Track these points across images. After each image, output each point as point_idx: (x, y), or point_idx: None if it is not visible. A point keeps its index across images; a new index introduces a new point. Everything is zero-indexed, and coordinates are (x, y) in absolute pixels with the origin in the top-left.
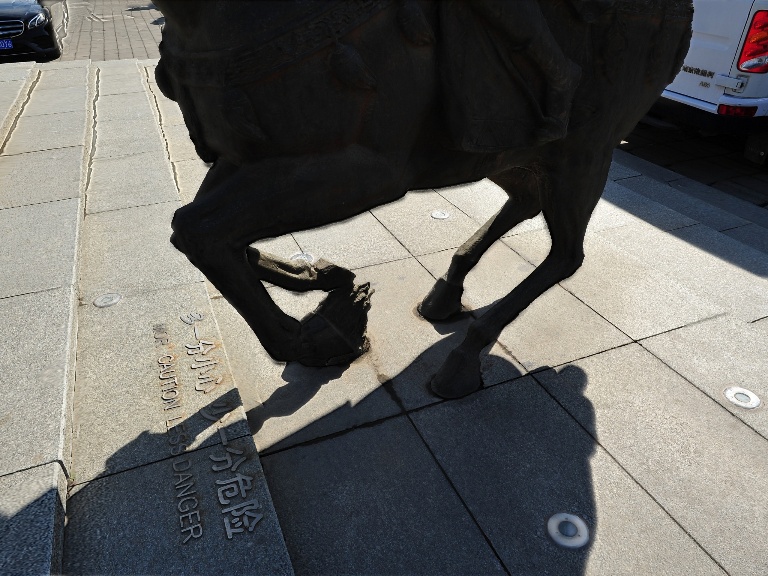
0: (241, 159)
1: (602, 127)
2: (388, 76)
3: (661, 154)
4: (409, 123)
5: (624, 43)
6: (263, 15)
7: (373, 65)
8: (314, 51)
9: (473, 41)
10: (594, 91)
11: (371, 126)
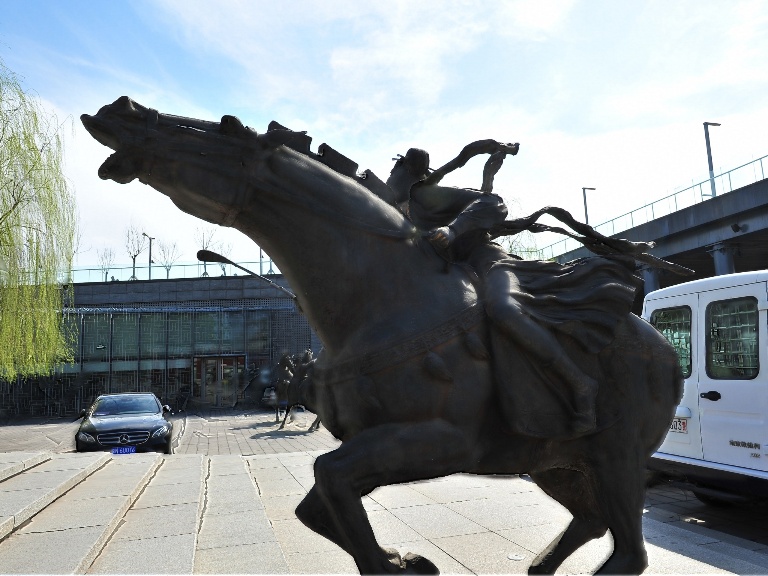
0: (363, 427)
1: (627, 429)
2: (461, 375)
3: (742, 531)
4: (477, 407)
5: (626, 368)
6: (385, 336)
7: (451, 367)
8: (414, 355)
9: (516, 360)
10: (612, 399)
11: (451, 406)
